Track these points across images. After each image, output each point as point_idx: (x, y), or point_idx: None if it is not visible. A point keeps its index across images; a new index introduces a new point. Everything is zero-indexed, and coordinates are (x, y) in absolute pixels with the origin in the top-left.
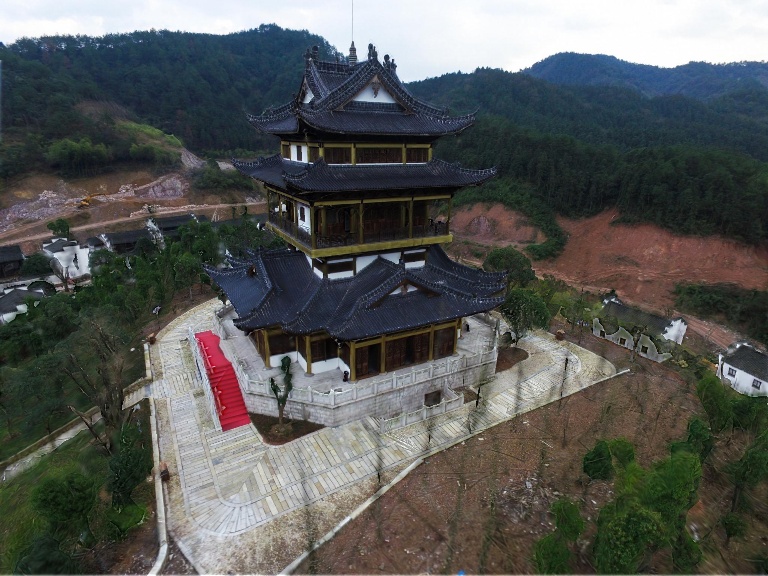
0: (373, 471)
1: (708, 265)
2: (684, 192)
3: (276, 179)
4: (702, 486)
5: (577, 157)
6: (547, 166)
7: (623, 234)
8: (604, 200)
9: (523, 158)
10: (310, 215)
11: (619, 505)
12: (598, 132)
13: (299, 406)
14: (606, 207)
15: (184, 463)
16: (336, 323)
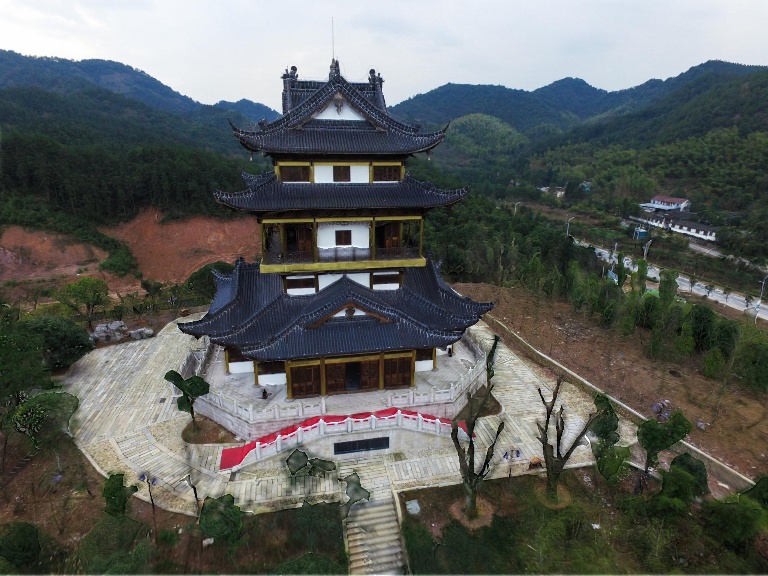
0: (533, 375)
1: (256, 239)
2: (214, 185)
3: (371, 202)
4: (555, 301)
5: (71, 160)
6: (51, 172)
7: (179, 230)
8: (135, 202)
9: (1, 165)
10: (370, 234)
11: (666, 275)
12: (5, 129)
13: (475, 382)
14: (140, 208)
15: (519, 459)
16: (452, 310)
